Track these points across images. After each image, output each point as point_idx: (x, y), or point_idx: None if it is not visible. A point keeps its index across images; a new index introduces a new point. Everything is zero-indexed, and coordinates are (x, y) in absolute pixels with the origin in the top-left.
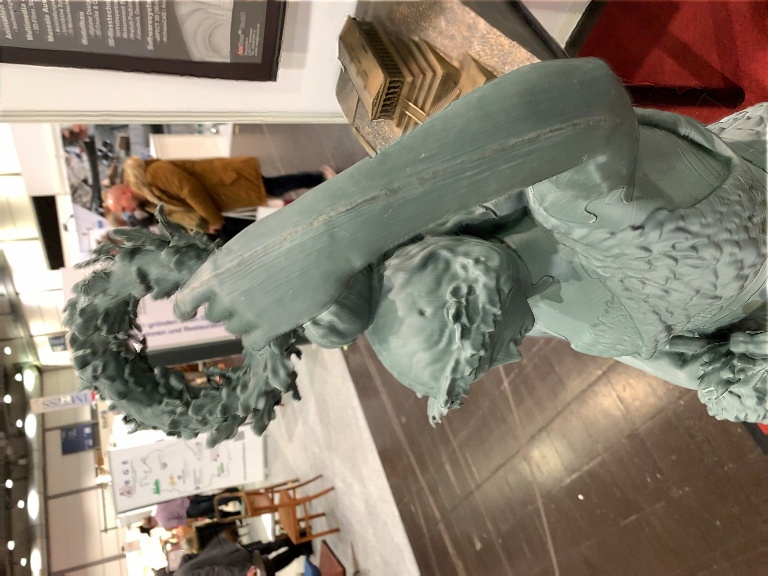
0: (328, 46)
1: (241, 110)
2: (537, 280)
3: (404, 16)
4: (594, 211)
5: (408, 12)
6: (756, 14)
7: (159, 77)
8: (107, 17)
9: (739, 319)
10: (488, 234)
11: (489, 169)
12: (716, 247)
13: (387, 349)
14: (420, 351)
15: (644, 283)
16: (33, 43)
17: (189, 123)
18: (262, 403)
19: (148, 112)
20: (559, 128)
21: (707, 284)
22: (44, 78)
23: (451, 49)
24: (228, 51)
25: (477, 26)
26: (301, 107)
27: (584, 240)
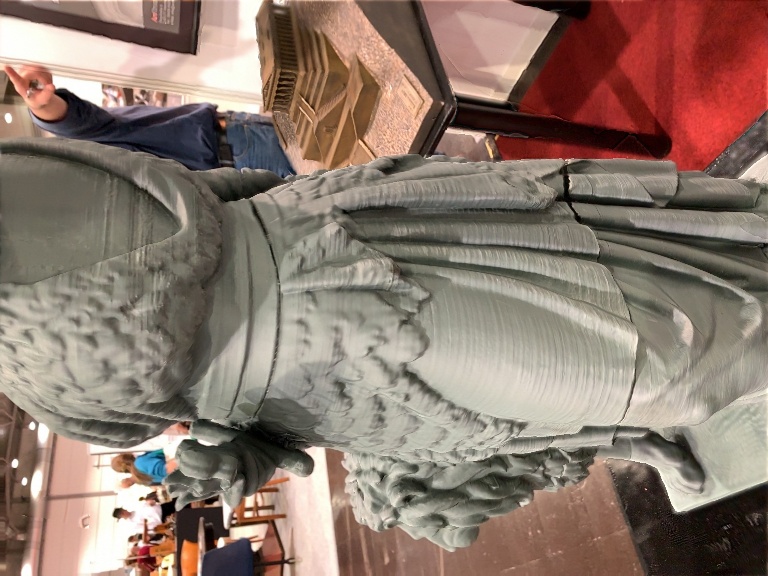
0: None
1: (168, 79)
2: None
3: (310, 5)
4: None
5: (313, 1)
6: (697, 59)
7: (70, 32)
8: None
9: (257, 419)
10: None
11: None
12: (54, 339)
13: None
14: None
15: (0, 366)
16: None
17: (109, 85)
18: None
19: (66, 67)
20: None
21: (62, 382)
22: None
23: (344, 47)
24: (141, 16)
25: (364, 26)
26: (233, 86)
27: None
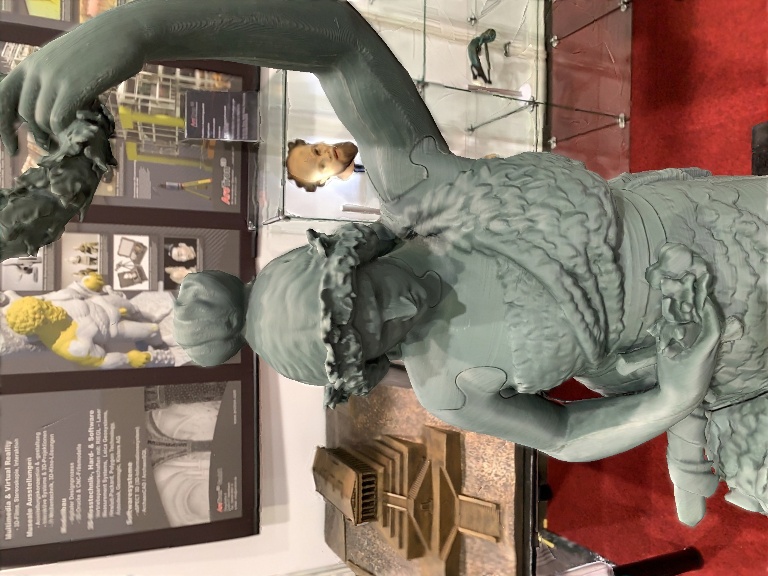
0: (306, 487)
1: None
2: (421, 275)
3: (364, 424)
4: (421, 163)
5: (366, 419)
6: None
7: (137, 556)
8: (88, 498)
9: None
10: None
11: None
12: (545, 170)
13: (261, 312)
14: (289, 283)
15: (507, 221)
16: (10, 543)
17: None
18: (62, 157)
19: None
20: None
21: (560, 200)
22: None
23: (410, 430)
24: (207, 510)
25: None
26: (292, 566)
27: (434, 204)
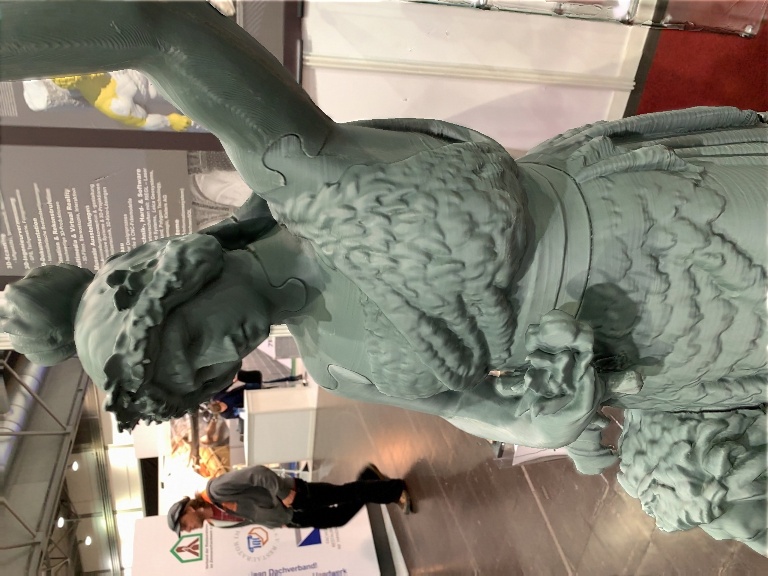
0: None
1: None
2: (281, 282)
3: None
4: (277, 168)
5: None
6: None
7: None
8: None
9: None
10: (242, 249)
11: None
12: (428, 197)
13: (75, 342)
14: (91, 330)
15: (368, 255)
16: None
17: None
18: None
19: None
20: None
21: (433, 243)
22: None
23: None
24: None
25: None
26: None
27: (294, 214)
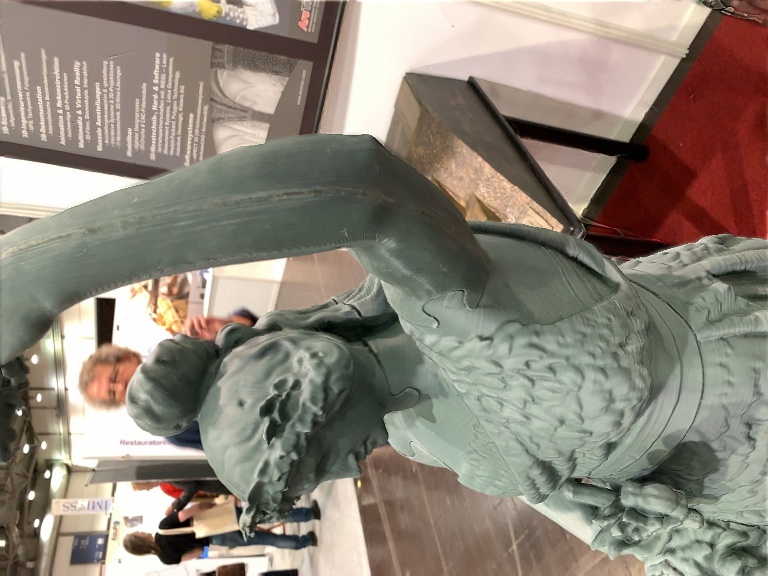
0: None
1: None
2: (399, 391)
3: (420, 157)
4: (434, 314)
5: (424, 154)
6: None
7: None
8: (152, 135)
9: (649, 471)
10: (357, 336)
11: (206, 222)
12: (576, 371)
13: (206, 441)
14: (231, 445)
15: (502, 404)
16: (83, 150)
17: None
18: None
19: None
20: (298, 192)
21: (570, 414)
22: (89, 182)
23: (459, 189)
24: None
25: (483, 170)
26: None
27: (435, 348)
